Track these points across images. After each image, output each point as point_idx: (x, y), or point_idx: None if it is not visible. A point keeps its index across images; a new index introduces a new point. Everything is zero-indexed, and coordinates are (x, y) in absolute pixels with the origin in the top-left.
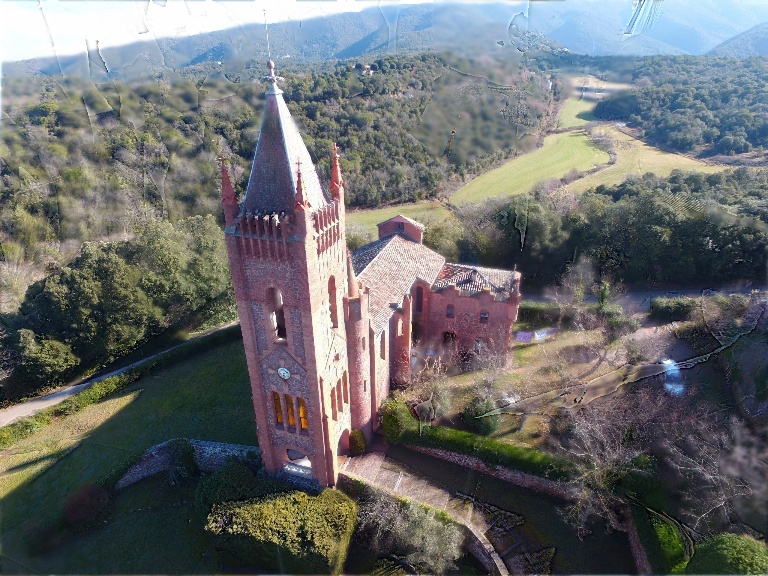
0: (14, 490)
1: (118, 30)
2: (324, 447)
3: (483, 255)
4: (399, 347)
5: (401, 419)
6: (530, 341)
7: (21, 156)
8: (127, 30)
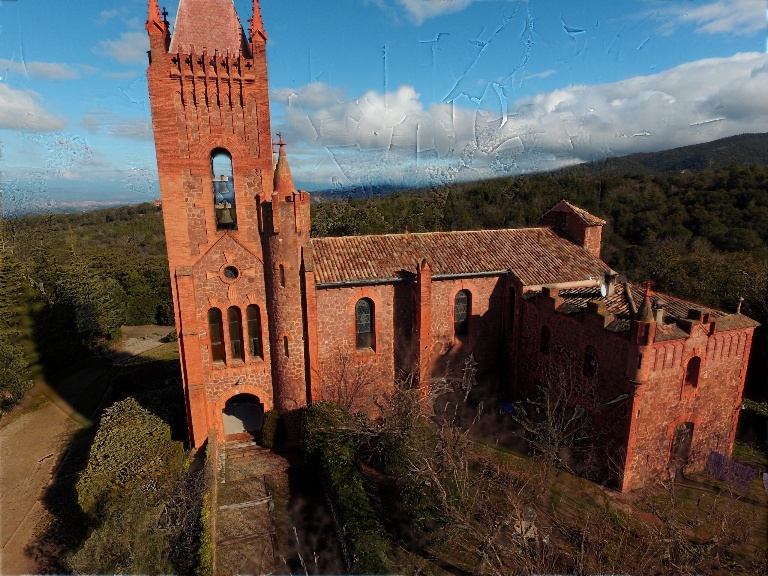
0: (162, 360)
1: (448, 75)
2: (184, 379)
3: (767, 319)
4: (414, 349)
5: (310, 422)
6: (754, 494)
7: (357, 174)
8: (454, 74)
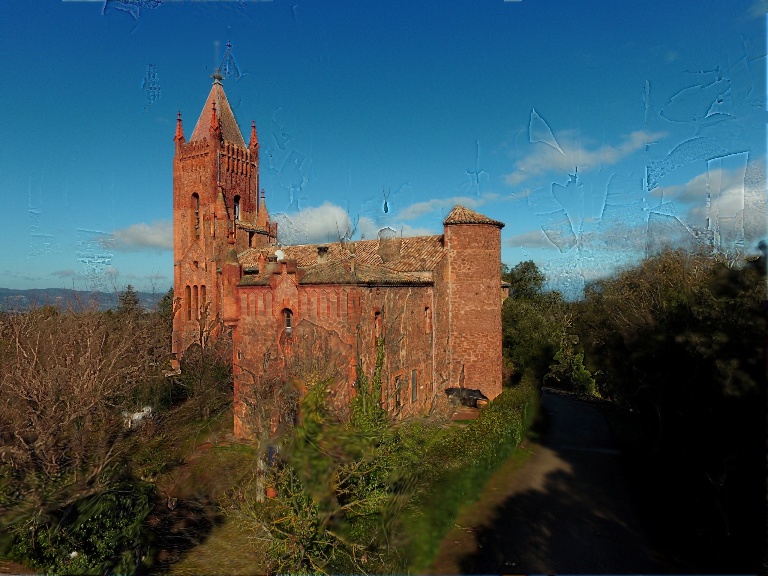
0: None
1: None
2: None
3: None
4: None
5: None
6: None
7: (565, 239)
8: None
